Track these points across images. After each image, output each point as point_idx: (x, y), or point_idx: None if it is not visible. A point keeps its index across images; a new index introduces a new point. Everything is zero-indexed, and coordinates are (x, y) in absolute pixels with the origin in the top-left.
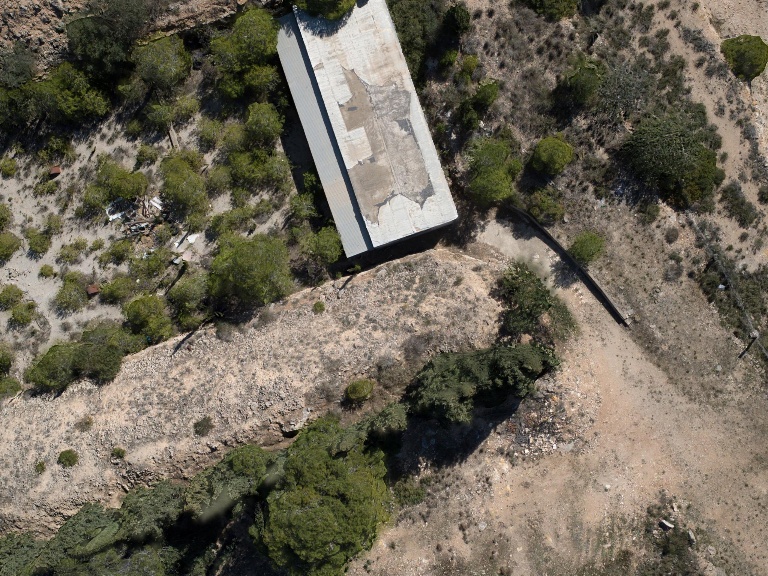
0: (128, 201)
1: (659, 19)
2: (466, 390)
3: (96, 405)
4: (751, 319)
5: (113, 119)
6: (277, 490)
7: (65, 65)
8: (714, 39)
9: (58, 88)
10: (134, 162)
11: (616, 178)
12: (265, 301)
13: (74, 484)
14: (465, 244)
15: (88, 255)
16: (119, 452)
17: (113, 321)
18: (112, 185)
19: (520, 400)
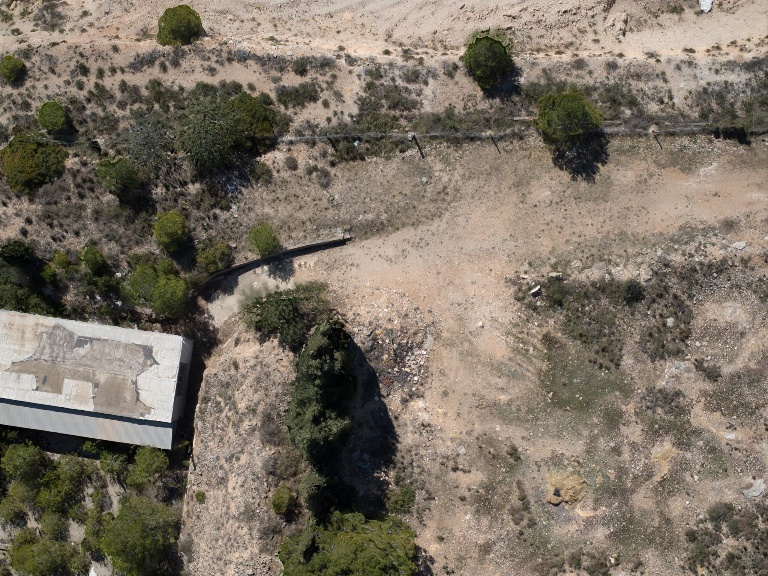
0: None
1: (110, 83)
2: (308, 415)
3: None
4: (396, 132)
5: None
6: None
7: None
8: (150, 46)
9: None
10: None
11: (219, 186)
12: (171, 541)
13: None
14: (216, 339)
15: None
16: None
17: None
18: None
19: (366, 363)
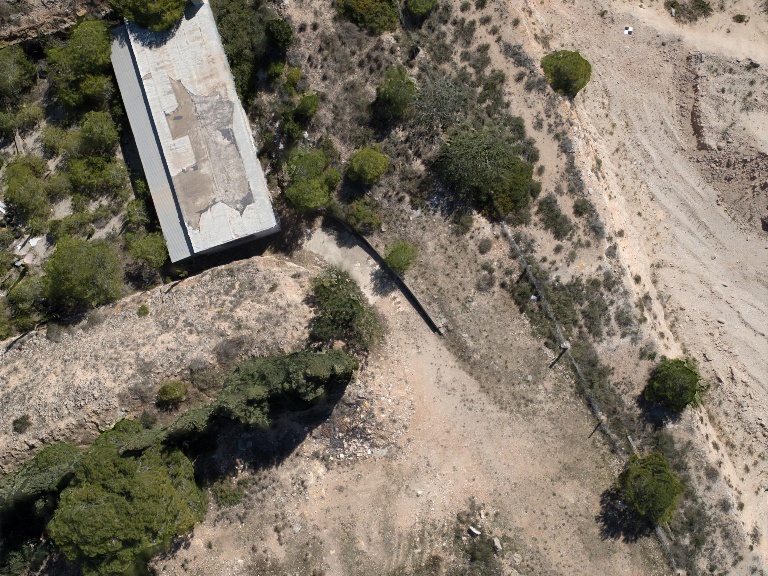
0: None
1: (481, 34)
2: (252, 393)
3: None
4: (562, 330)
5: None
6: (71, 486)
7: None
8: (534, 54)
9: None
10: None
11: (431, 189)
12: (93, 303)
13: None
14: (291, 251)
15: None
16: None
17: None
18: None
19: (333, 405)
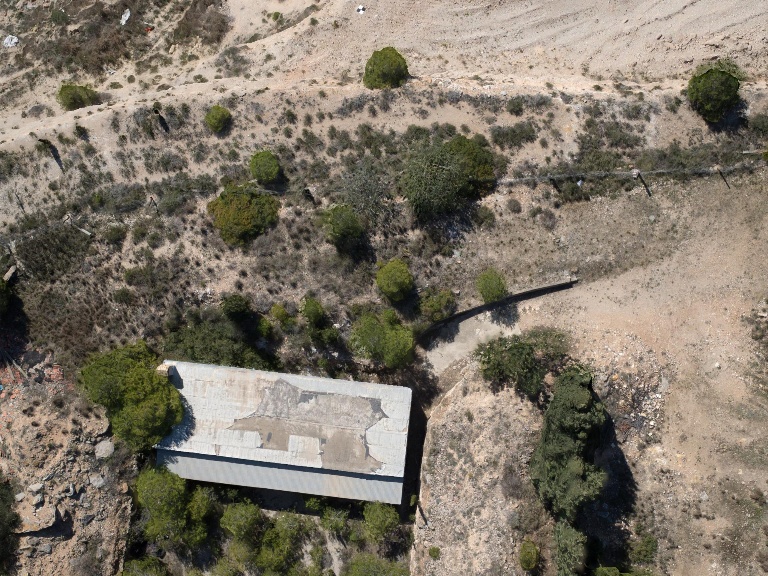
0: None
1: (318, 130)
2: (577, 470)
3: None
4: (620, 170)
5: None
6: None
7: None
8: (358, 91)
9: None
10: None
11: (441, 232)
12: None
13: None
14: (436, 388)
15: None
16: None
17: None
18: None
19: None
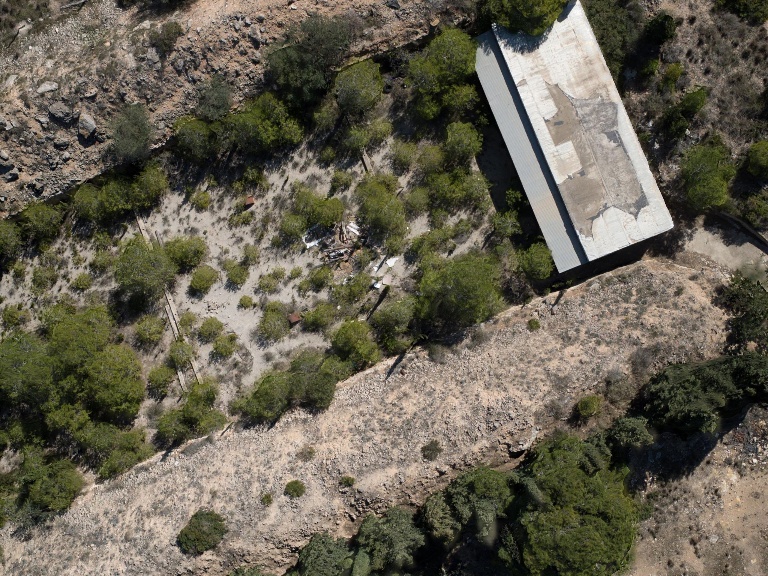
0: (324, 228)
1: None
2: (721, 400)
3: (314, 434)
4: None
5: (304, 147)
6: (530, 511)
7: (266, 95)
8: None
9: (260, 119)
10: (328, 189)
11: None
12: (478, 321)
13: (303, 515)
14: (674, 253)
15: (287, 284)
16: (348, 480)
17: (316, 349)
18: (310, 213)
19: (747, 409)
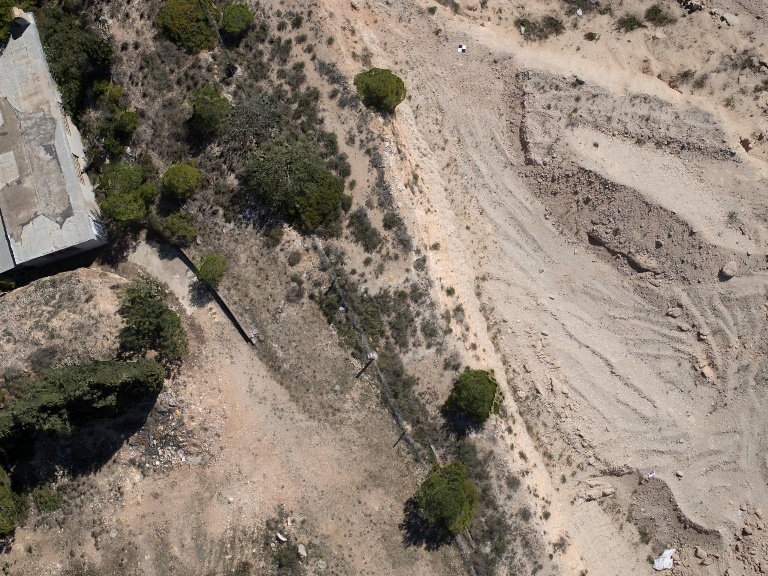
0: None
1: (297, 52)
2: (42, 400)
3: None
4: (369, 341)
5: None
6: None
7: None
8: (347, 72)
9: None
10: None
11: (243, 203)
12: None
13: None
14: (117, 263)
15: None
16: None
17: None
18: None
19: (147, 413)
